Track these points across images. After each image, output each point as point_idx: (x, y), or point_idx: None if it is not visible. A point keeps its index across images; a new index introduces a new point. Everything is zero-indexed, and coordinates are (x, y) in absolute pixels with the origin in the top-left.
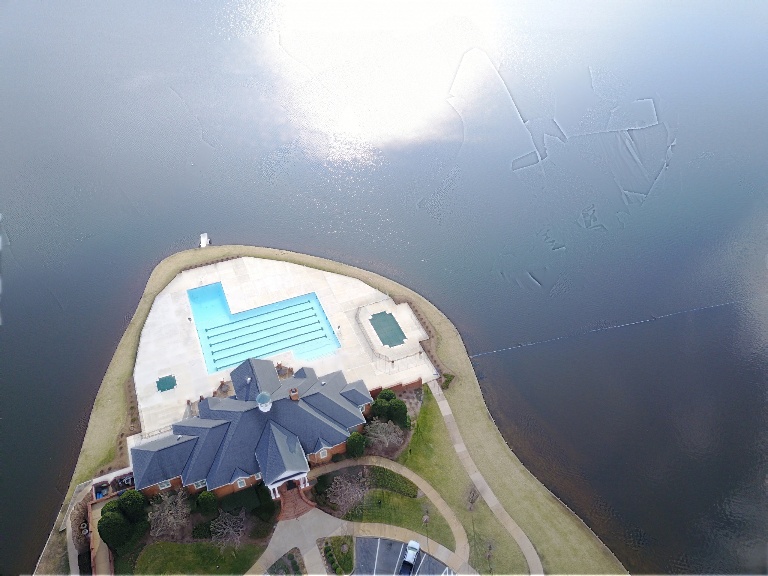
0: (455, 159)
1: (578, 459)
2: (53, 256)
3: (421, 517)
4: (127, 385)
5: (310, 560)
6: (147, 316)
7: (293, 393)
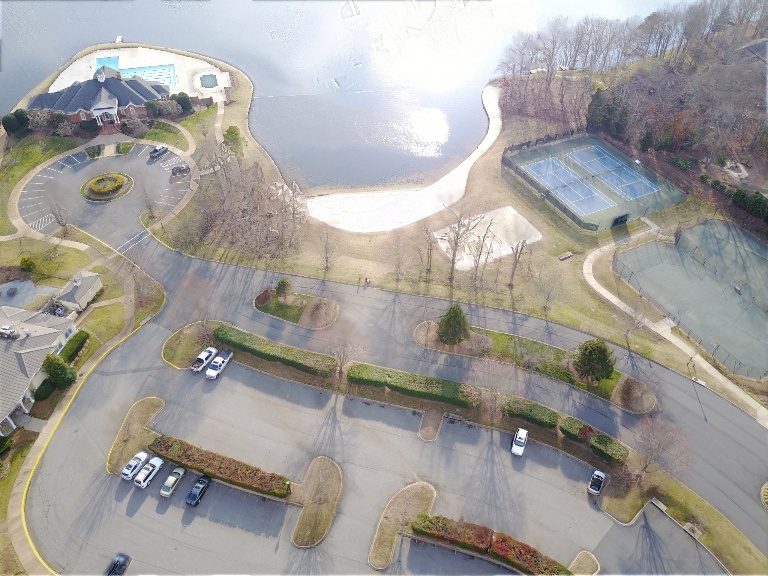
0: (302, 7)
1: (288, 139)
2: (25, 45)
3: (176, 140)
4: (44, 91)
5: (108, 148)
6: (68, 67)
7: (117, 73)
